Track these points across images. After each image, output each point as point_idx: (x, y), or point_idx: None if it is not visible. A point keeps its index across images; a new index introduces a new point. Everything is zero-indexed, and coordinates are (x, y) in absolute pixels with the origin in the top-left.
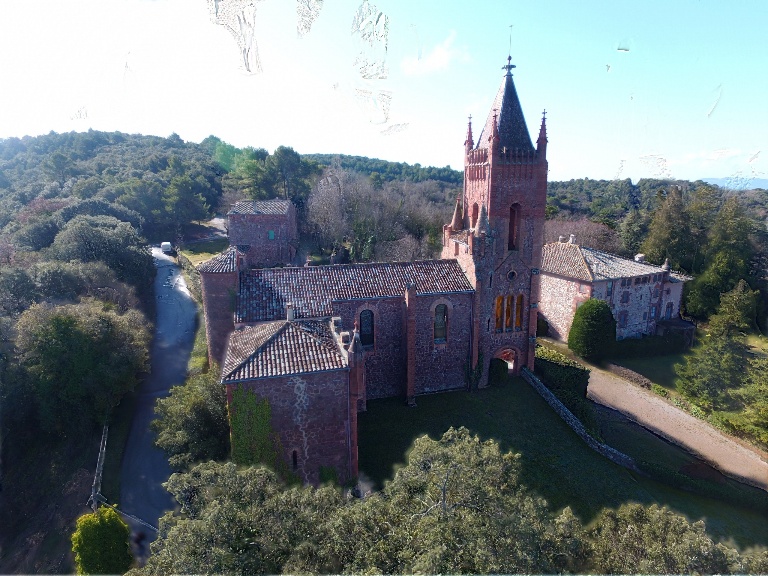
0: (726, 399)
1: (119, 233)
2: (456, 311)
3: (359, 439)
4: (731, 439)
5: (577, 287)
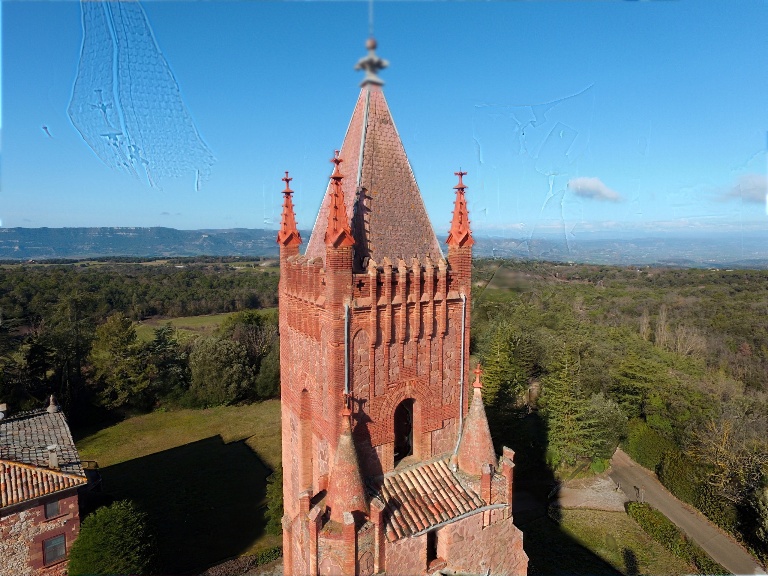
0: None
1: None
2: None
3: None
4: None
5: (37, 515)
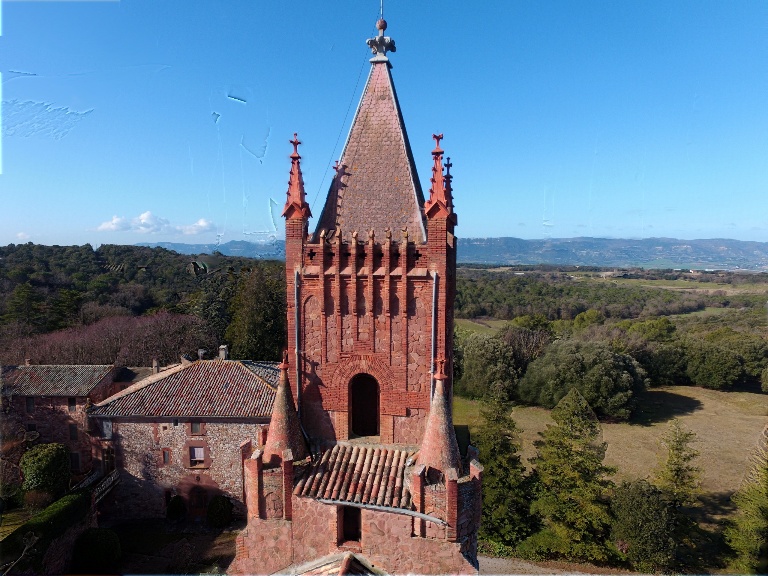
0: (526, 521)
1: None
2: None
3: None
4: (552, 567)
5: None
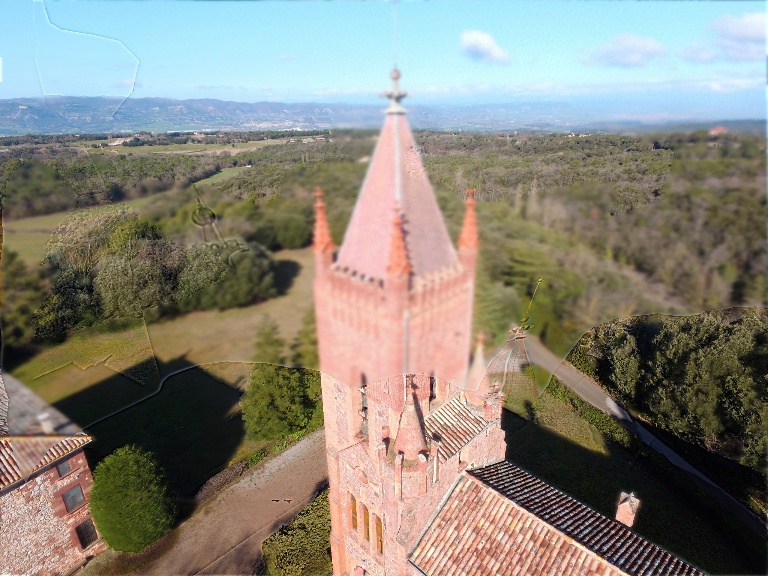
0: (308, 405)
1: None
2: None
3: None
4: None
5: (52, 476)
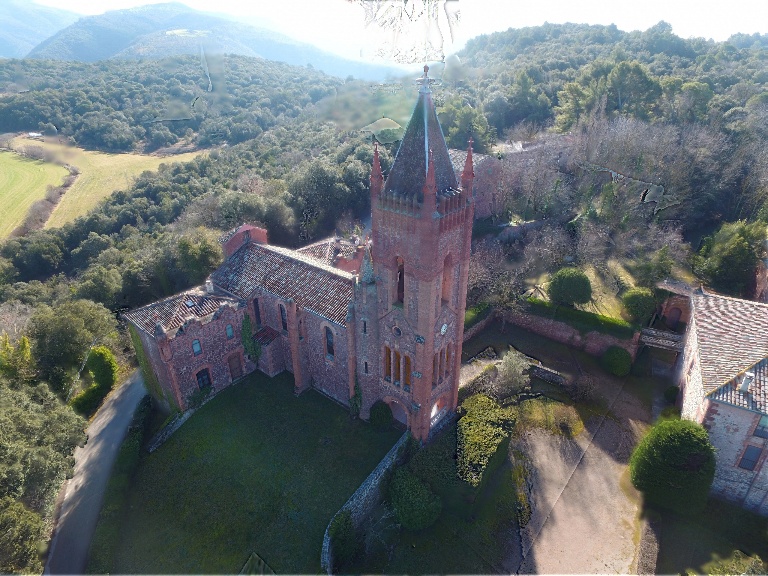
0: None
1: (351, 168)
2: (339, 339)
3: (234, 391)
4: None
5: None
